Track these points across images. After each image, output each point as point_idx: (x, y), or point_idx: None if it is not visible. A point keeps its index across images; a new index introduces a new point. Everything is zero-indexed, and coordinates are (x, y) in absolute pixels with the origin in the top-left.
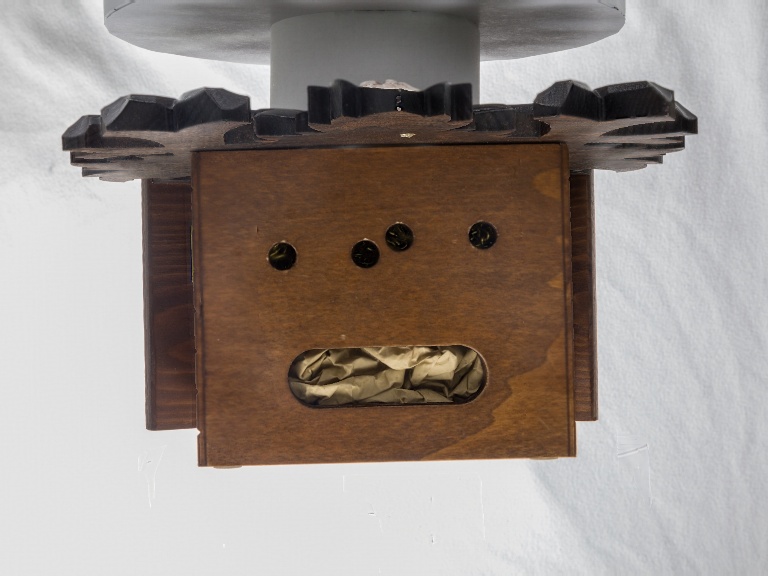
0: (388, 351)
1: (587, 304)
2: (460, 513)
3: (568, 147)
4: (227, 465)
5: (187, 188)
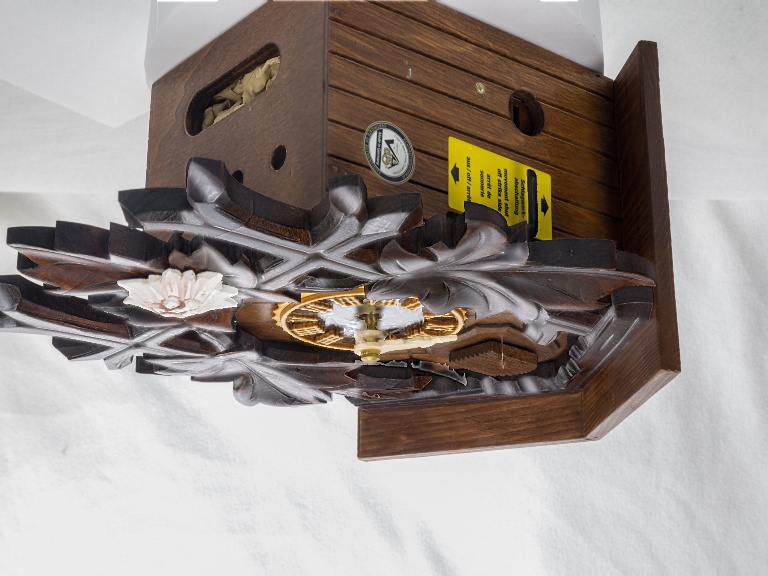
0: None
1: None
2: None
3: None
4: None
5: None
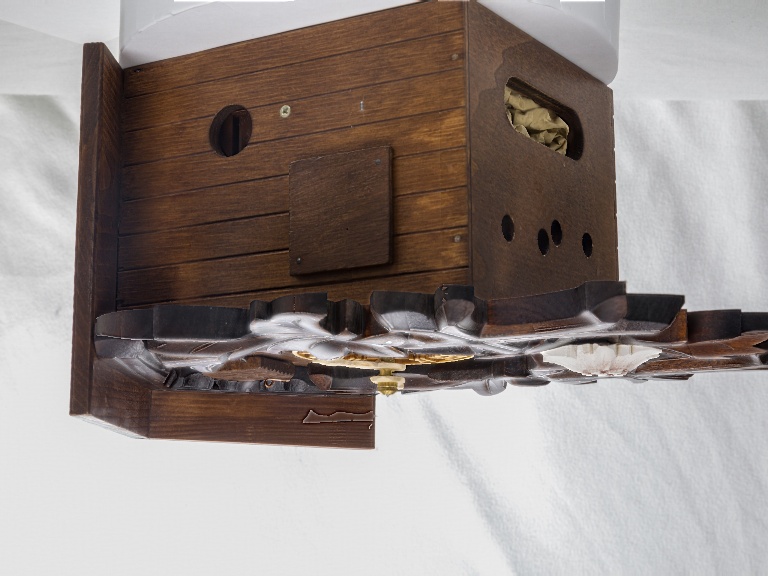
0: None
1: None
2: None
3: None
4: None
5: None
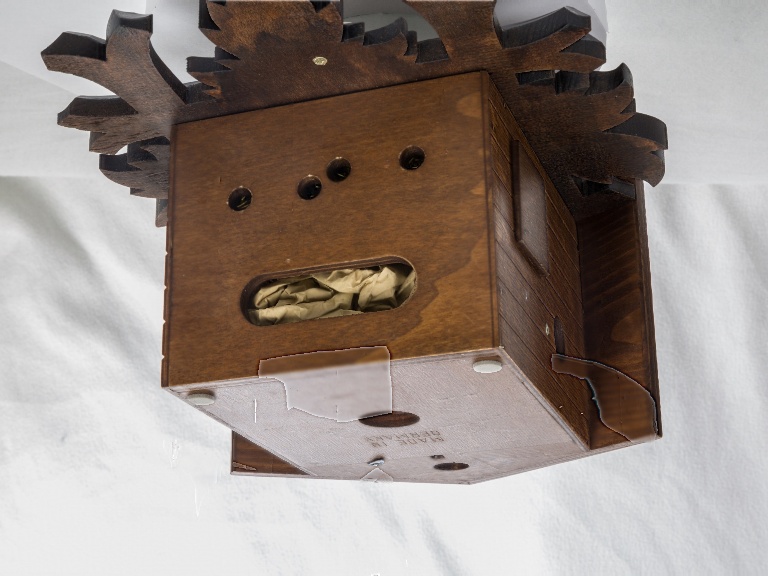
0: (335, 277)
1: (640, 321)
2: (365, 385)
3: (512, 93)
4: (185, 383)
5: None
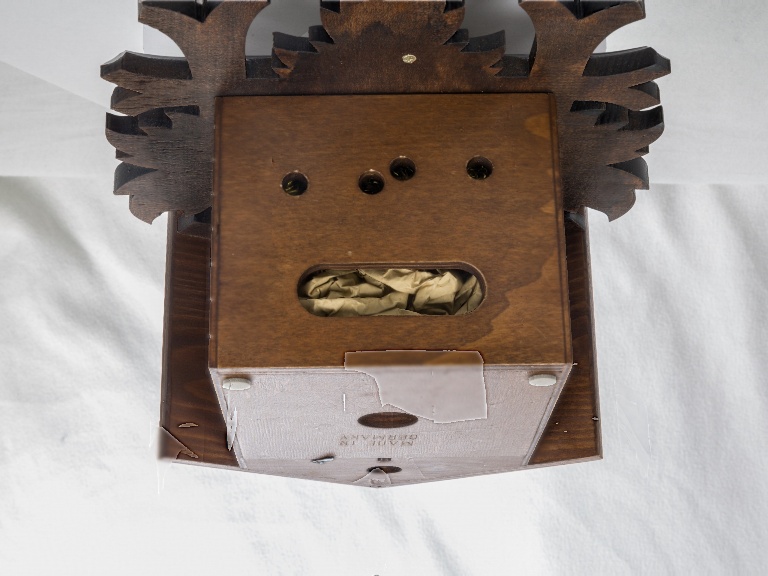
0: (392, 275)
1: (587, 346)
2: (460, 389)
3: None
4: (236, 367)
5: (209, 243)
